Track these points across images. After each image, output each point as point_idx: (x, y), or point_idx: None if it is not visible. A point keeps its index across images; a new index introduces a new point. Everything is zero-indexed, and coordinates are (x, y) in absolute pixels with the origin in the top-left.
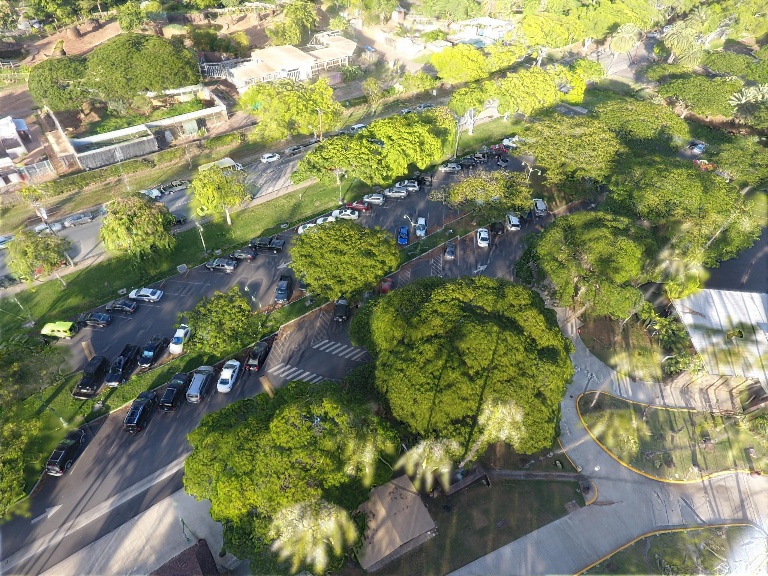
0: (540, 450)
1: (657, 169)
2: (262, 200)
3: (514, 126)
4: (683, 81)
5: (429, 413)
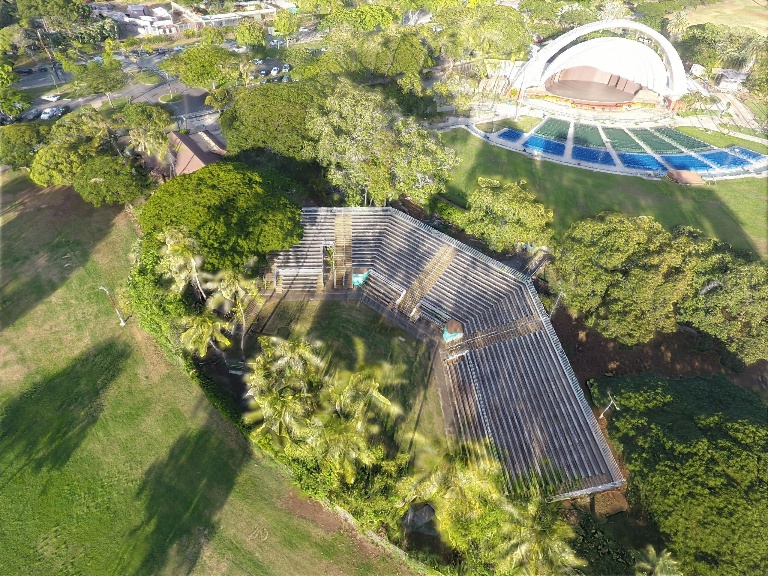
0: None
1: None
2: (302, 42)
3: (438, 25)
4: (531, 2)
5: (376, 60)
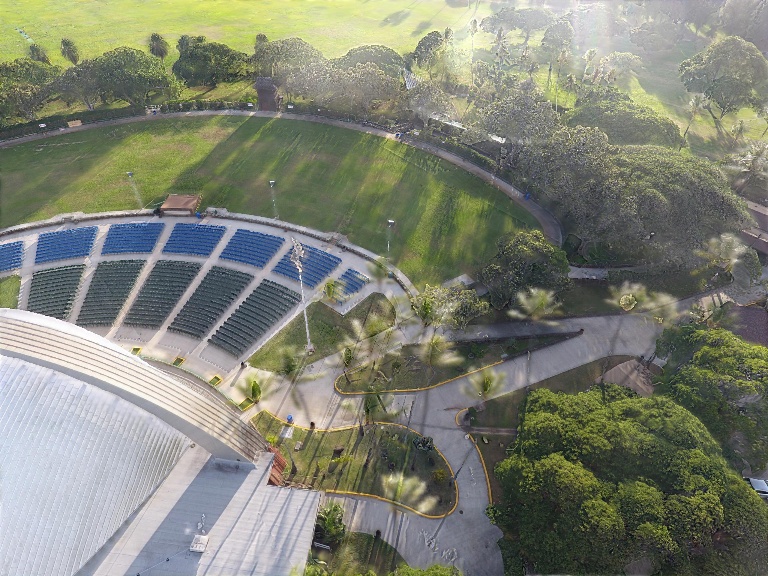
0: None
1: None
2: None
3: None
4: None
5: None
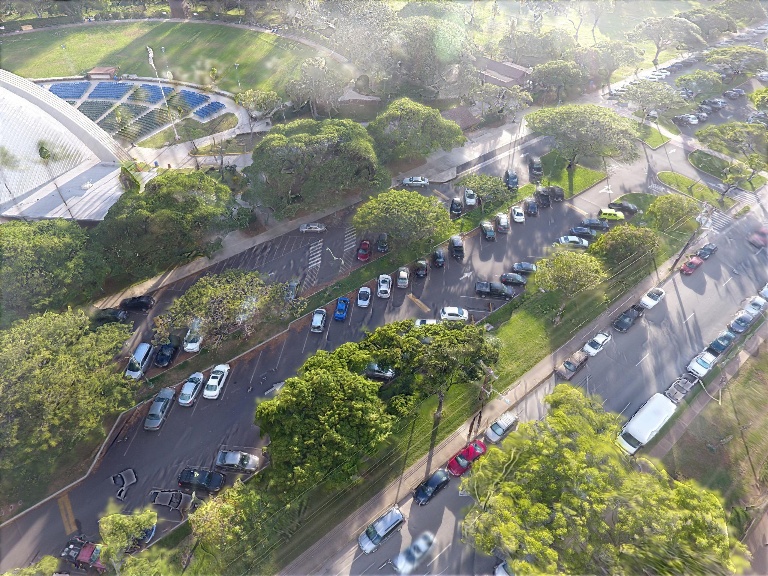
0: None
1: (0, 269)
2: (540, 368)
3: None
4: None
5: None
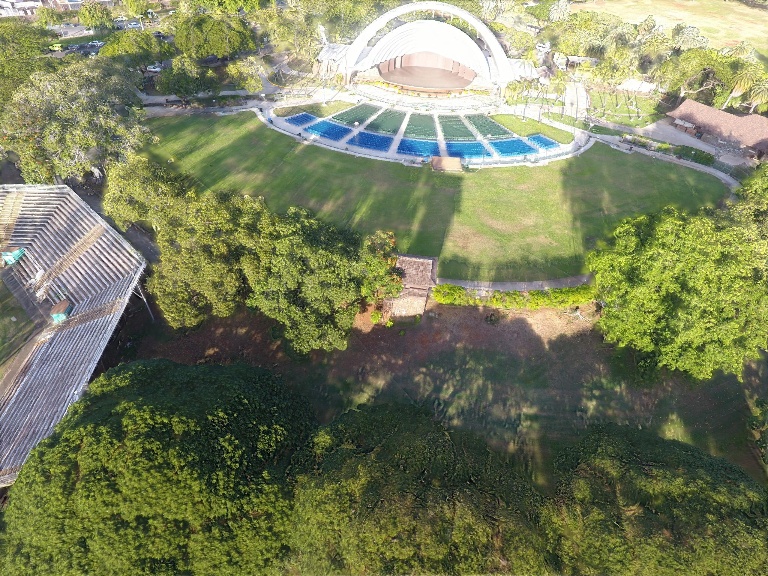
0: (225, 56)
1: None
2: None
3: None
4: None
5: (186, 41)
